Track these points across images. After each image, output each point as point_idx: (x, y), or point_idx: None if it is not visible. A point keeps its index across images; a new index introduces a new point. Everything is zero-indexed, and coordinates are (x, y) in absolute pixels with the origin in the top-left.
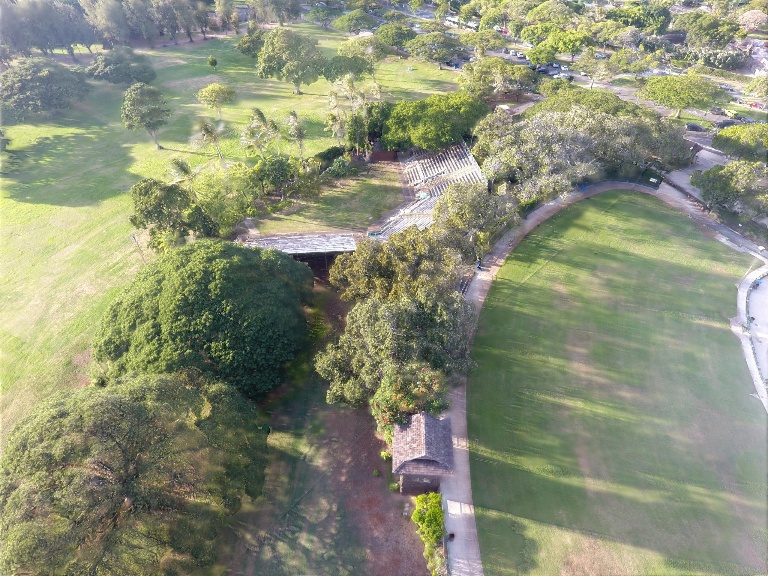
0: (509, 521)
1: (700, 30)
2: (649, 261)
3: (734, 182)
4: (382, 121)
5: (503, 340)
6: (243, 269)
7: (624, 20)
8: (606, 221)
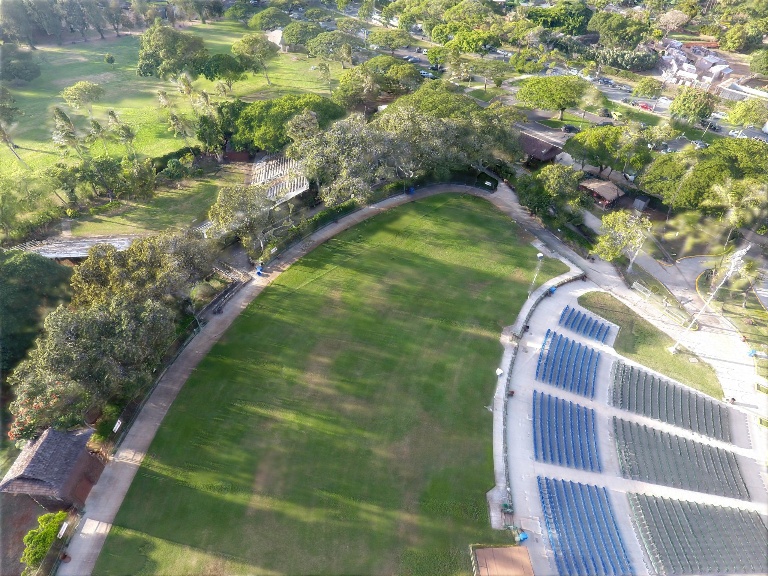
0: (141, 541)
1: (609, 30)
2: (447, 267)
3: (547, 186)
4: (233, 121)
5: (242, 349)
6: None
7: (544, 20)
8: (421, 225)
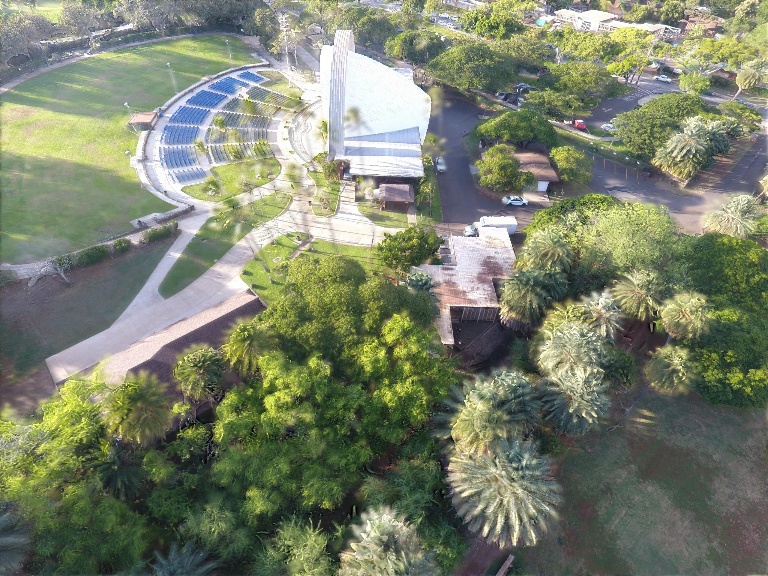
0: None
1: None
2: (193, 58)
3: (256, 21)
4: None
5: (66, 71)
6: None
7: None
8: (191, 44)
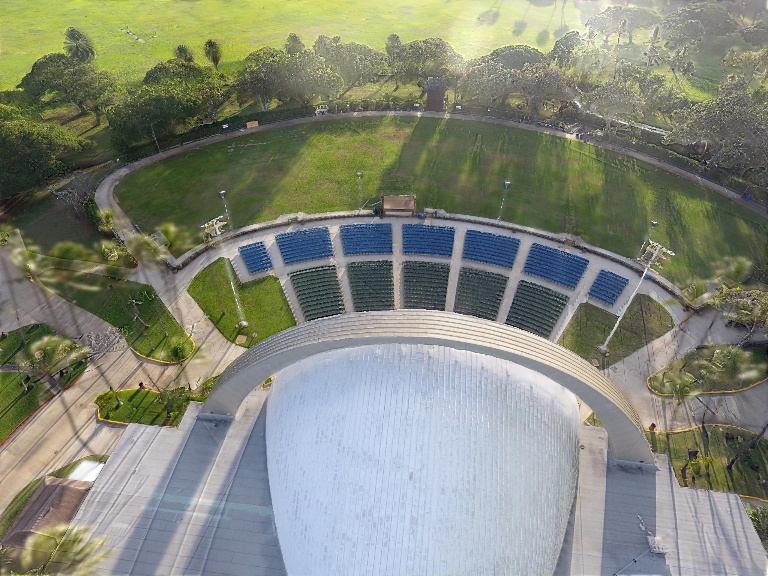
0: None
1: None
2: (639, 213)
3: None
4: None
5: (513, 134)
6: (522, 58)
7: None
8: (692, 203)
